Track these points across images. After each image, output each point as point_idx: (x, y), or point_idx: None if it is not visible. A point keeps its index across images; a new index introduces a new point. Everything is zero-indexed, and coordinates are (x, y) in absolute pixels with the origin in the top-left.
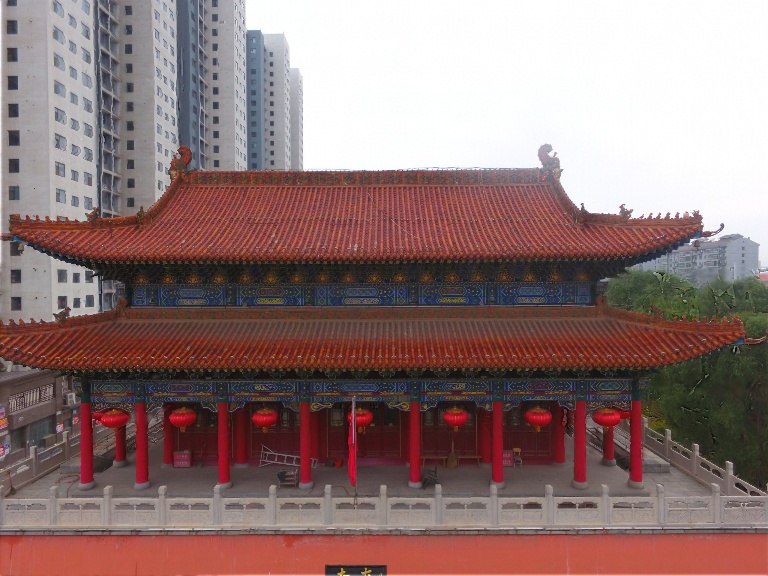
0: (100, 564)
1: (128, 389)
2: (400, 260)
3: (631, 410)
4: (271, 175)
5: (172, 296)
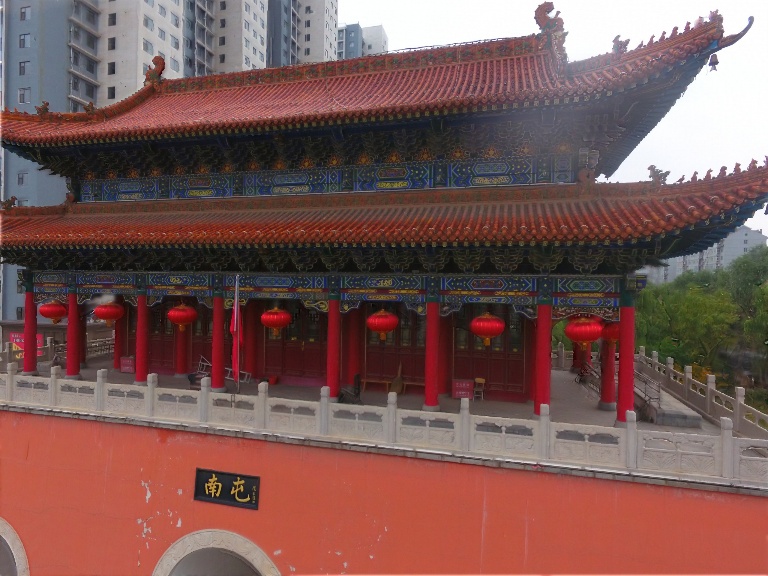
0: (0, 439)
1: (62, 279)
2: (308, 122)
3: (619, 321)
4: (234, 76)
5: (113, 191)
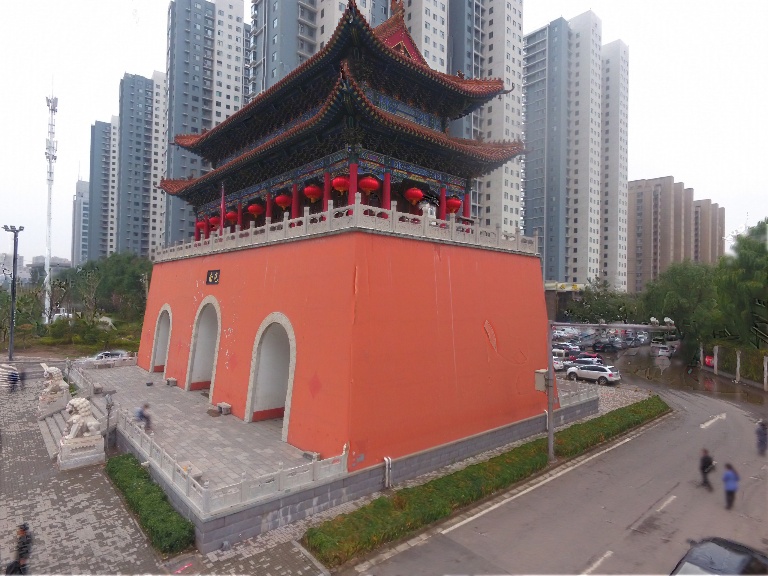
0: None
1: None
2: (253, 105)
3: None
4: None
5: None
